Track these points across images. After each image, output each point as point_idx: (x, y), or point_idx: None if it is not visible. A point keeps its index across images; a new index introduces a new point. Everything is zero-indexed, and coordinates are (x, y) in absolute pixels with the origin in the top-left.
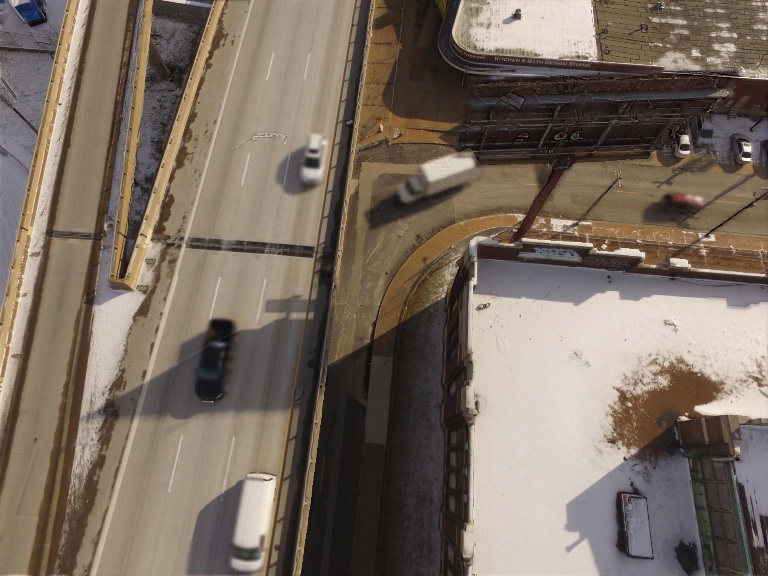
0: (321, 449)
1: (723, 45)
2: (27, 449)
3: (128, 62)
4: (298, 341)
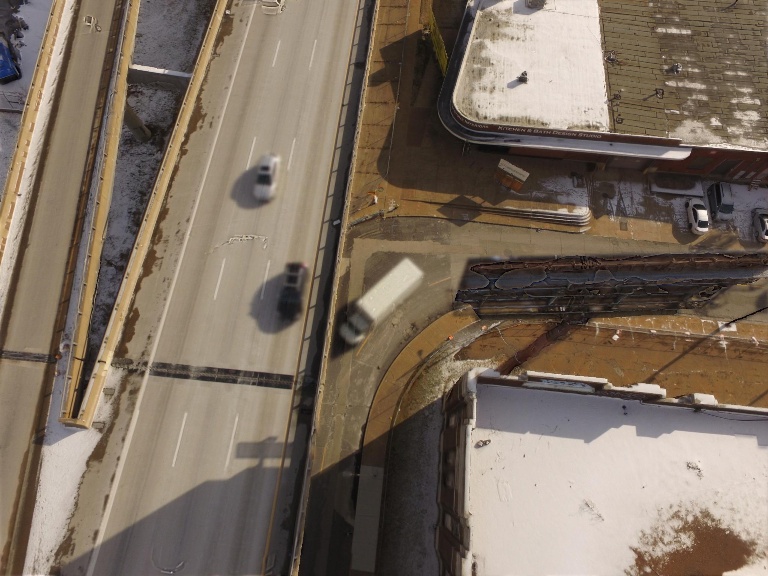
0: None
1: (745, 113)
2: None
3: (96, 145)
4: (272, 495)
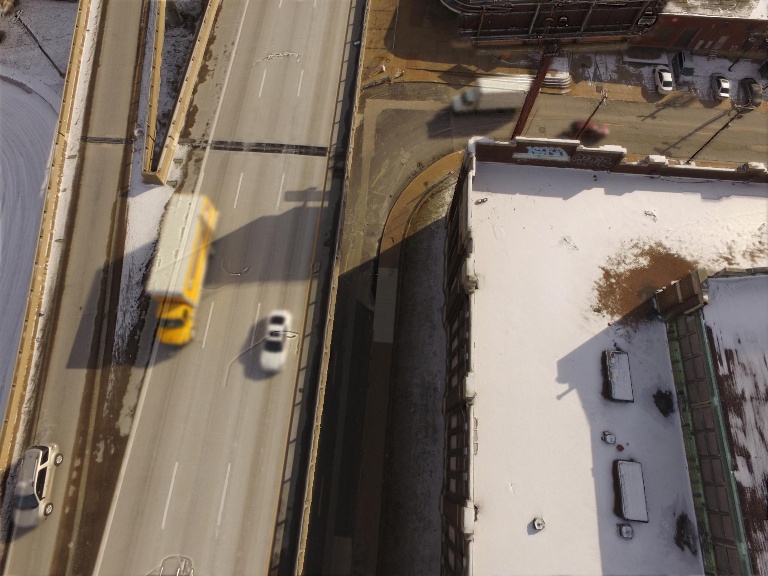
0: (333, 348)
1: None
2: (73, 316)
3: None
4: (315, 225)
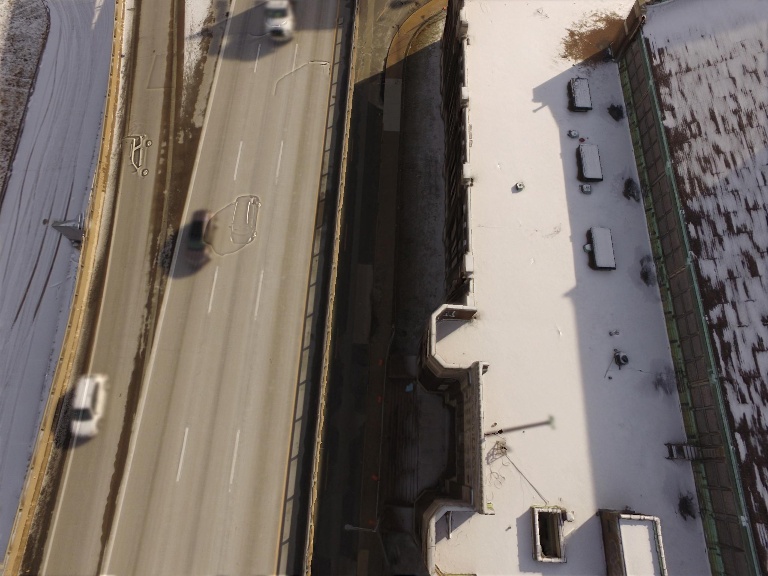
0: (350, 135)
1: None
2: (149, 56)
3: None
4: None
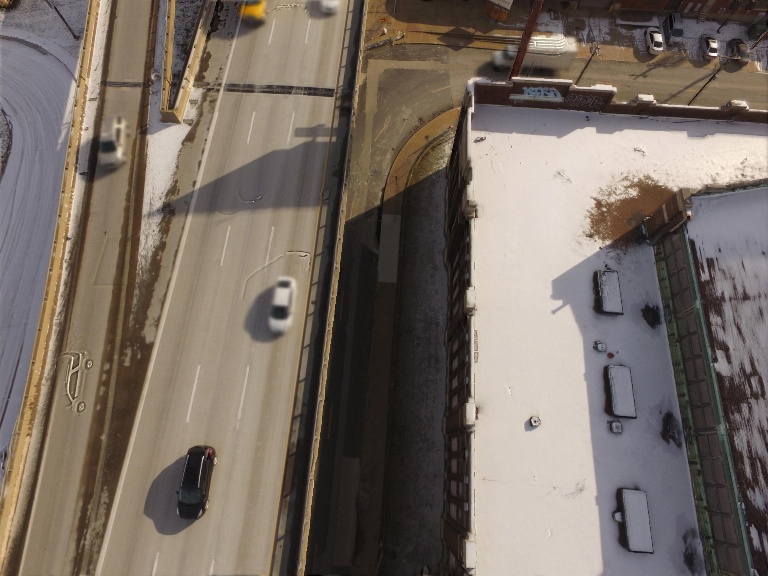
0: (340, 287)
1: None
2: (99, 239)
3: None
4: (324, 157)
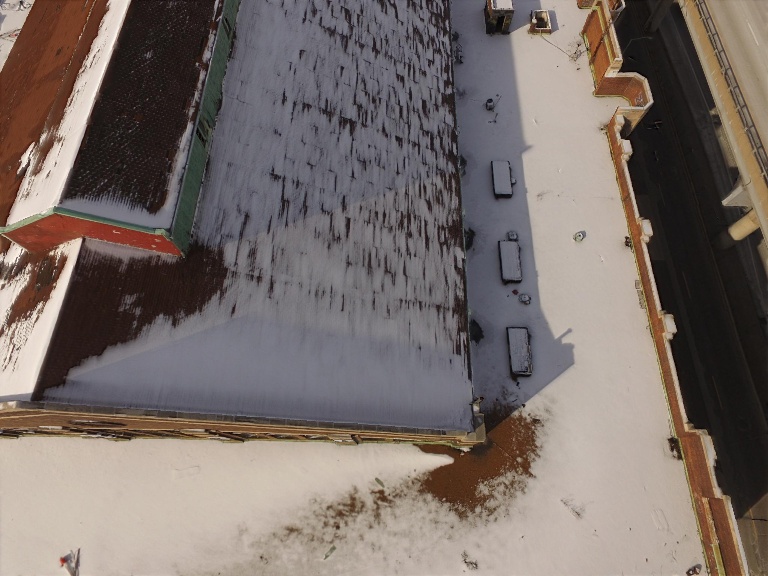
0: (728, 413)
1: None
2: None
3: None
4: None
